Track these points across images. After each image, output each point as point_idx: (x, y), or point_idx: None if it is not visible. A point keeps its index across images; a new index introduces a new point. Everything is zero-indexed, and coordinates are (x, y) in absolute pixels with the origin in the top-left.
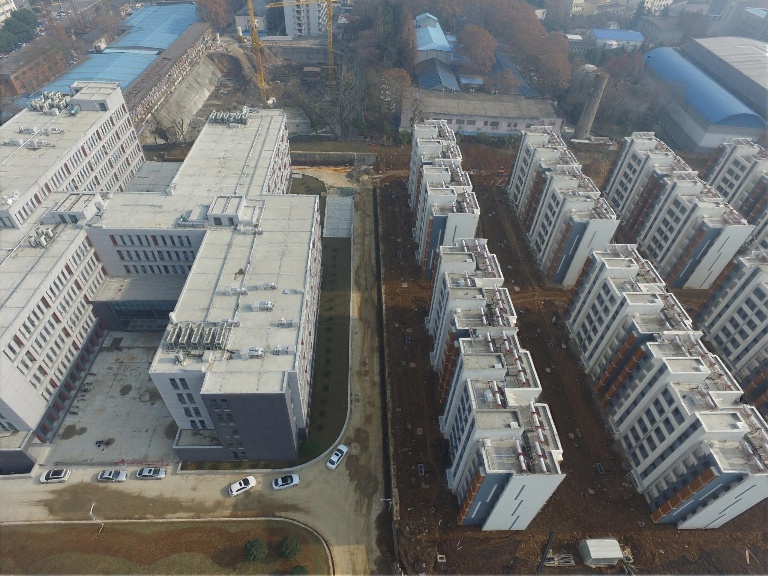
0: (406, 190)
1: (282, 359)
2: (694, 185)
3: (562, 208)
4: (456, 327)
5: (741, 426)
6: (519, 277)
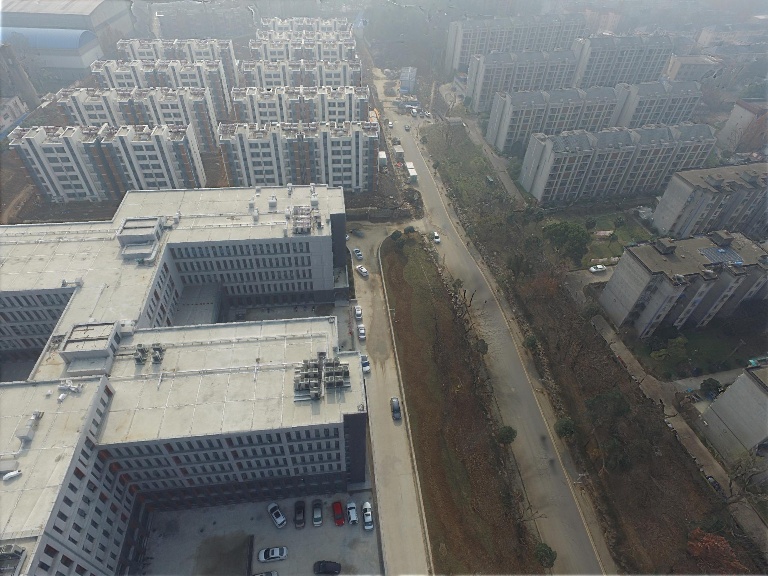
0: (58, 205)
1: (318, 191)
2: (177, 62)
3: (184, 102)
4: (295, 139)
5: (351, 87)
6: (207, 160)
